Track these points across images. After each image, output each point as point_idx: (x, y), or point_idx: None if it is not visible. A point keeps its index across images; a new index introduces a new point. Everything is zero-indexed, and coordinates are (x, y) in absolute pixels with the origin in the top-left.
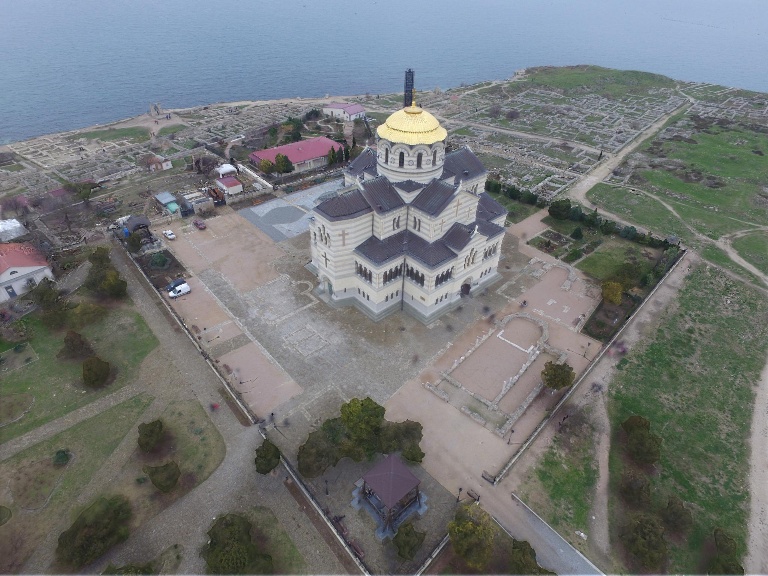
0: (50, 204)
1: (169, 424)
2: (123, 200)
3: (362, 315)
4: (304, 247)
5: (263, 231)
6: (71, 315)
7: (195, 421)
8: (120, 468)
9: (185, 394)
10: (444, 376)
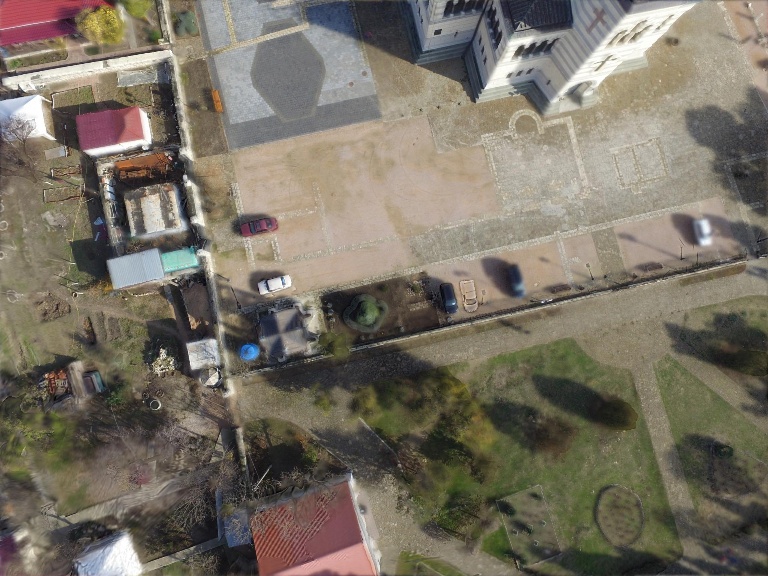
0: (5, 499)
1: (713, 345)
2: (55, 354)
3: (625, 76)
4: (418, 82)
5: (333, 127)
6: (484, 447)
7: (719, 318)
8: (752, 397)
9: (675, 322)
10: (766, 41)
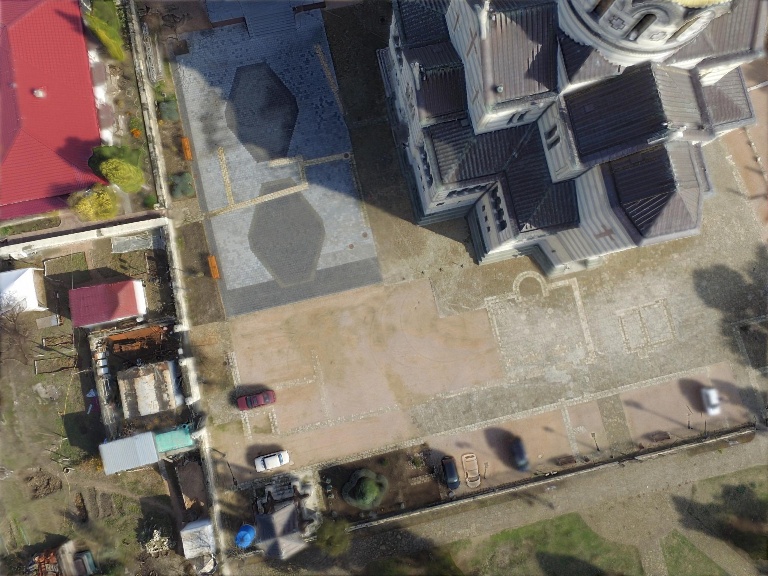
0: None
1: (721, 519)
2: (45, 533)
3: None
4: (420, 243)
5: (332, 293)
6: None
7: (728, 490)
8: (761, 574)
9: (682, 495)
10: None
